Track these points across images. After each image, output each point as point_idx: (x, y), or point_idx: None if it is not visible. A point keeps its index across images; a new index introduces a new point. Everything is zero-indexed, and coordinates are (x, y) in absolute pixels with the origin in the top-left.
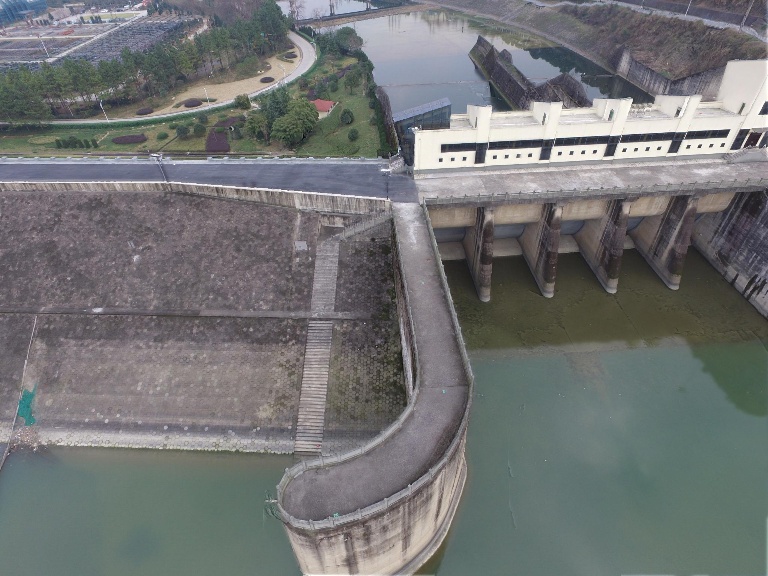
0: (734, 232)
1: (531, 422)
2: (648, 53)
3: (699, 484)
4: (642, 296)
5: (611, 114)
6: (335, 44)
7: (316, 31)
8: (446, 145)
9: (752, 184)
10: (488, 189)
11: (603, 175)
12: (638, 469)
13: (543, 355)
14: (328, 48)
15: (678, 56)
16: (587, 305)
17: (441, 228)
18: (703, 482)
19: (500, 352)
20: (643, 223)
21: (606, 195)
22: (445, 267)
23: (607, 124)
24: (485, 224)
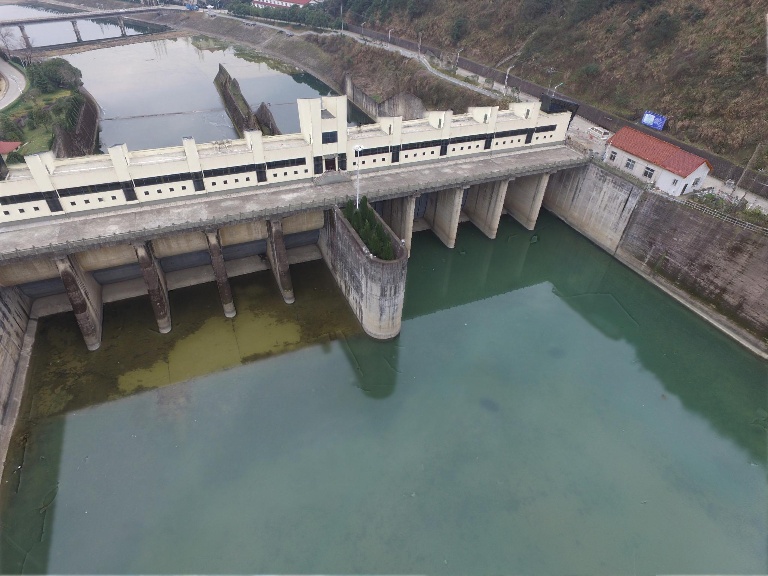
0: (332, 245)
1: (91, 473)
2: (367, 79)
3: (239, 491)
4: (258, 315)
5: (185, 152)
6: (43, 76)
7: (26, 62)
8: (5, 197)
9: (319, 204)
10: (60, 238)
11: (193, 209)
12: (186, 493)
13: (134, 396)
14: (35, 81)
15: (387, 81)
16: (201, 334)
17: (32, 282)
18: (244, 488)
19: (87, 403)
20: (267, 245)
21: (182, 230)
22: (63, 319)
23: (181, 162)
24: (60, 274)
